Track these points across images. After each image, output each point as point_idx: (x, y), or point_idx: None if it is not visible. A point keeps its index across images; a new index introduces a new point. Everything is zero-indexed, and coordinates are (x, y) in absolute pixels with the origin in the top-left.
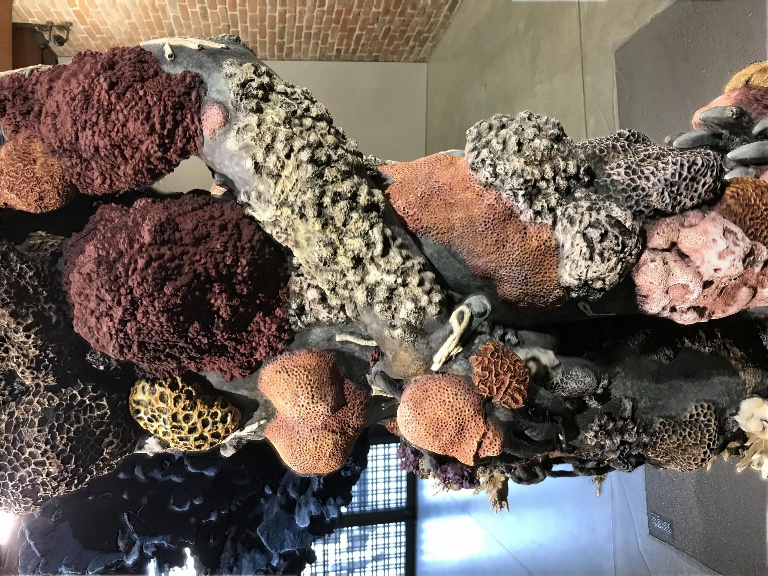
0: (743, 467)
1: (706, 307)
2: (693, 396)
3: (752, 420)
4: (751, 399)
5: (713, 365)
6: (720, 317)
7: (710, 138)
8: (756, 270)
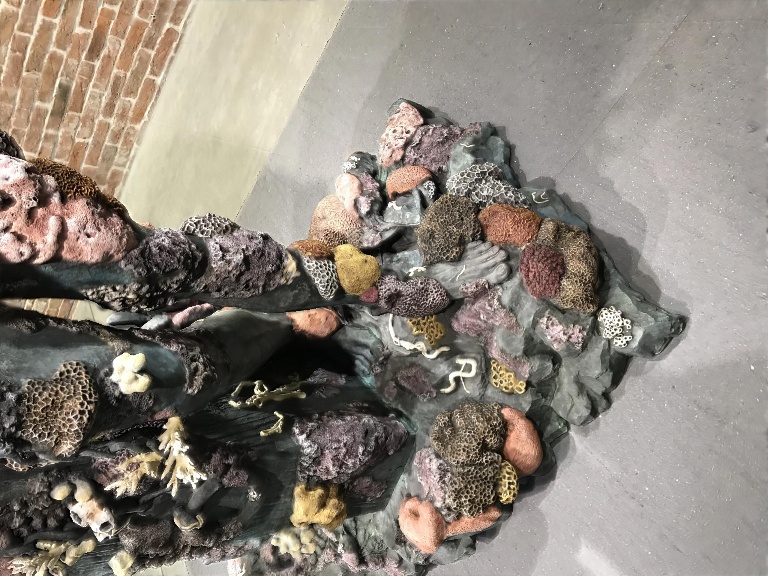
0: (174, 486)
1: (25, 236)
2: (61, 359)
3: (124, 372)
4: (119, 356)
5: (82, 340)
6: (47, 254)
7: (137, 314)
8: (56, 200)
